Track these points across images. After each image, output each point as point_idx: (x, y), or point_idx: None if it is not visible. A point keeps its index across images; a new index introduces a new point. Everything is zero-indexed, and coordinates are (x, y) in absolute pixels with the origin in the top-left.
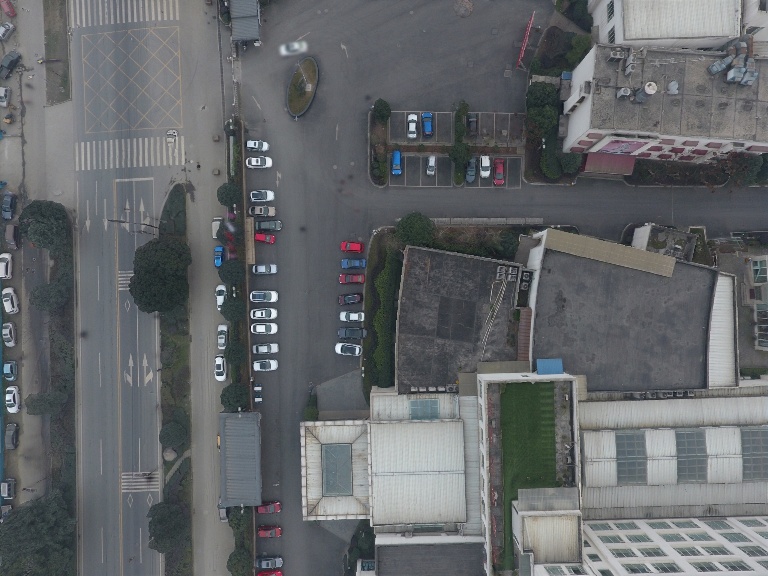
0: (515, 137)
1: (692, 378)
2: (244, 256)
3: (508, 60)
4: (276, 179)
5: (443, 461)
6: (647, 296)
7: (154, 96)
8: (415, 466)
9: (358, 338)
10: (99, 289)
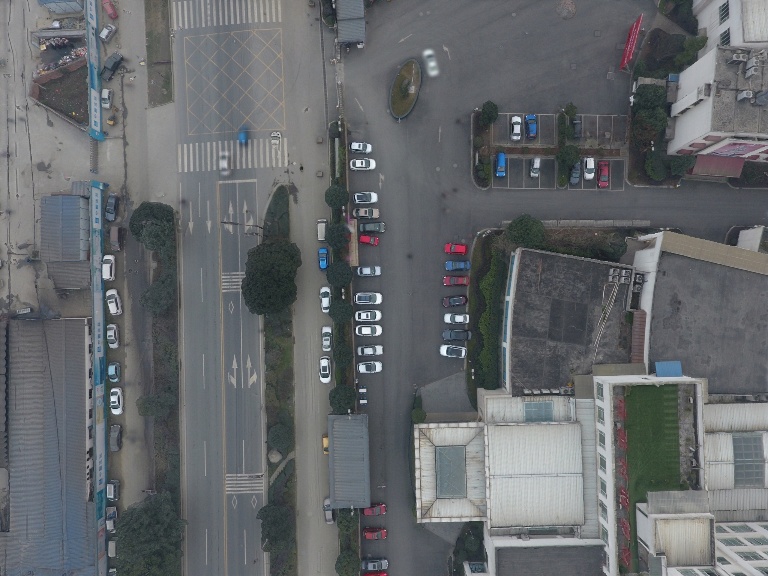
0: (618, 139)
1: None
2: (348, 258)
3: (611, 62)
4: (379, 181)
5: (561, 463)
6: (762, 299)
7: (257, 98)
8: (533, 468)
9: (463, 340)
10: (202, 291)
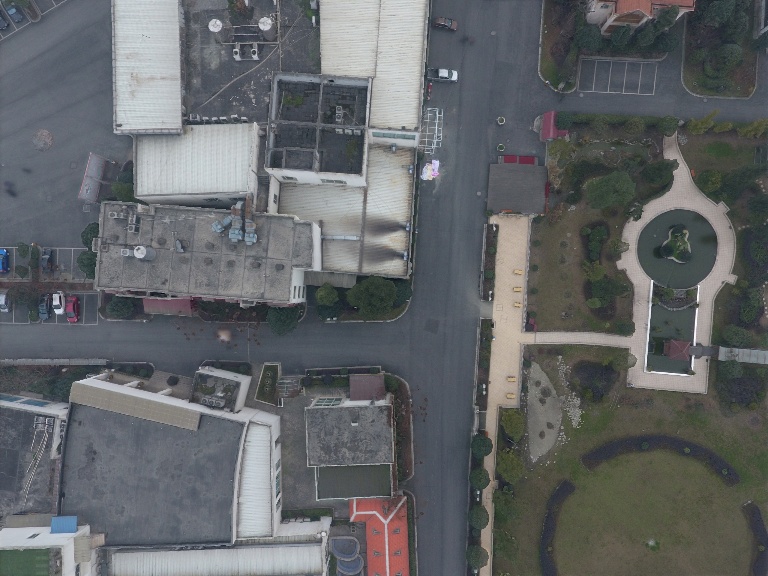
0: None
1: (221, 530)
2: None
3: None
4: None
5: None
6: (177, 448)
7: None
8: None
9: None
10: None
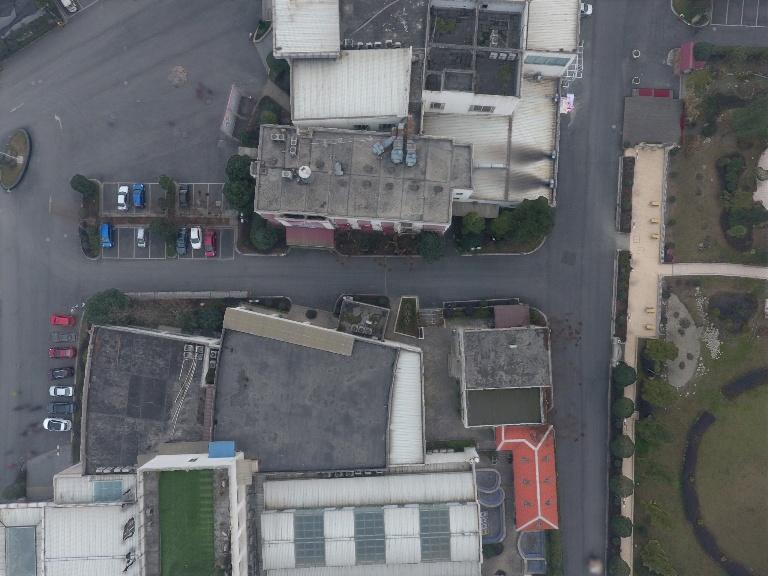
0: (228, 208)
1: (375, 457)
2: None
3: None
4: None
5: (117, 545)
6: (329, 374)
7: None
8: (89, 551)
9: (66, 413)
10: None
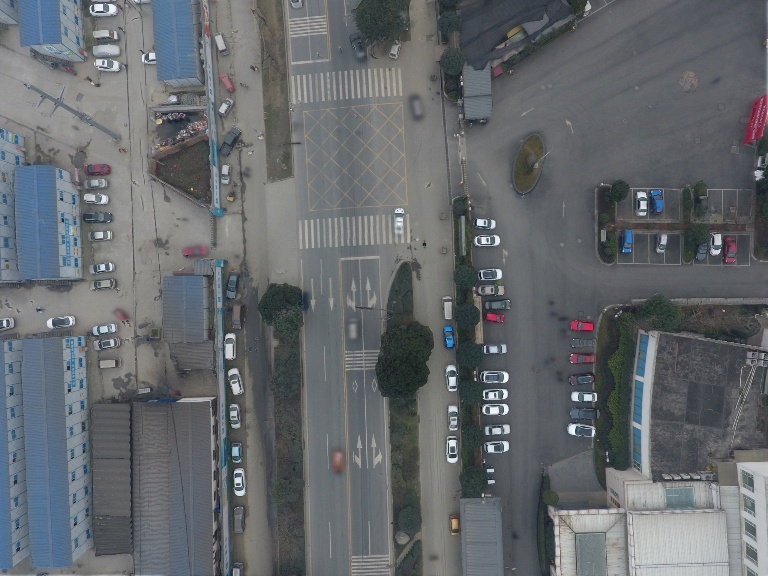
0: (743, 214)
1: None
2: None
3: (735, 136)
4: (503, 257)
5: (707, 553)
6: None
7: (379, 173)
8: (679, 558)
9: (591, 419)
10: (326, 369)
